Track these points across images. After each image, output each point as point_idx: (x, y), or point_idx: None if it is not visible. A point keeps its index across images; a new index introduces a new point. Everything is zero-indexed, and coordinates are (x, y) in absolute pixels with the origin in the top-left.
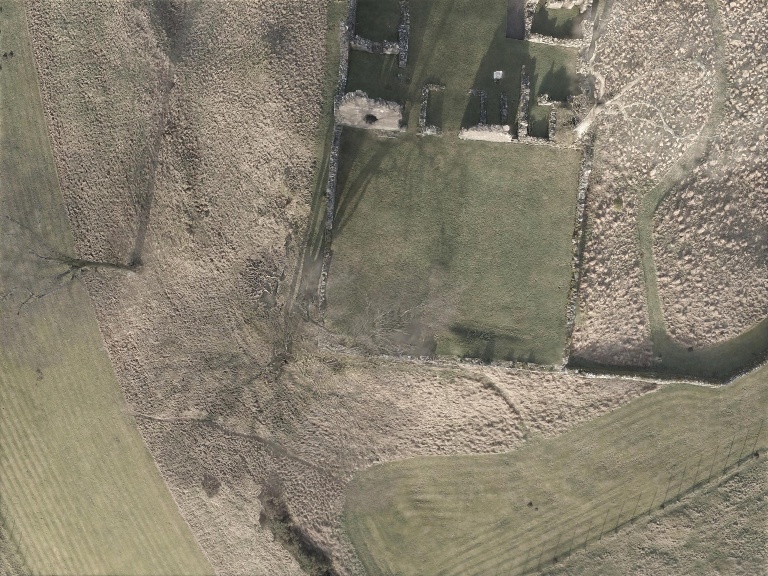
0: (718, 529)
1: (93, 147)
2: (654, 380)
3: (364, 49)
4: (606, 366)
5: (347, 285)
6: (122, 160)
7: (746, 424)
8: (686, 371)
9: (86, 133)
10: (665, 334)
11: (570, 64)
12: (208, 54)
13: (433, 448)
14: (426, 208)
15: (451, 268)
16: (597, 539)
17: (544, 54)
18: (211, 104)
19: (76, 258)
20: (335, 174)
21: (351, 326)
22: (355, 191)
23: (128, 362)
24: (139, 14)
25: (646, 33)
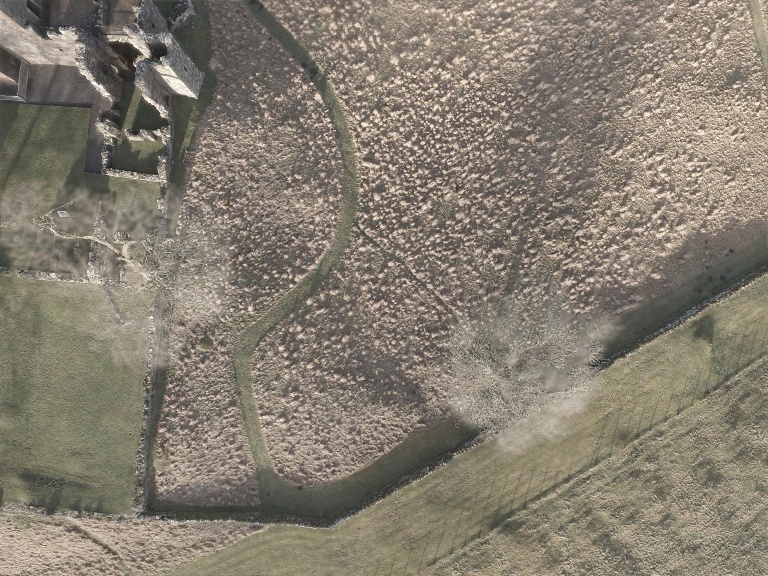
0: None
1: None
2: (250, 523)
3: None
4: (202, 508)
5: None
6: None
7: (362, 564)
8: (296, 510)
9: None
10: (273, 472)
11: (153, 199)
12: None
13: None
14: None
15: (23, 411)
16: None
17: (124, 188)
18: None
19: None
20: None
21: None
22: None
23: None
24: None
25: (251, 161)
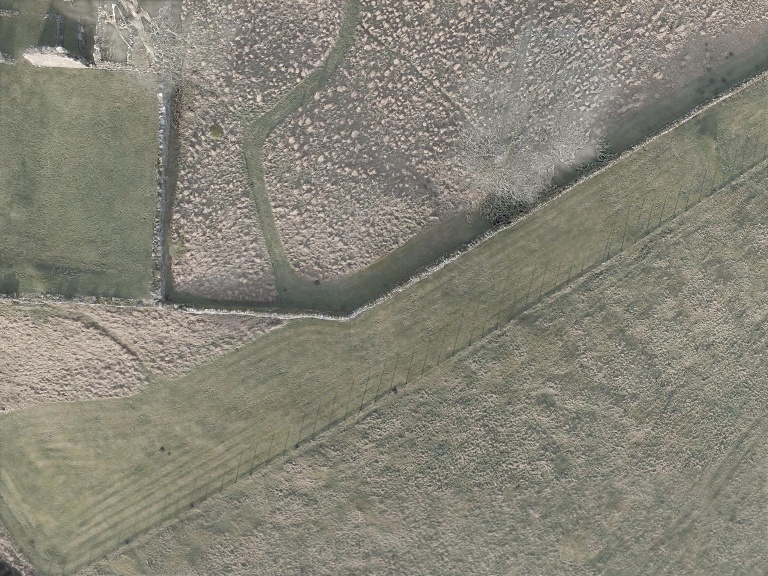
0: (358, 468)
1: None
2: (268, 314)
3: None
4: (219, 301)
5: None
6: None
7: (382, 358)
8: (313, 305)
9: None
10: (289, 267)
11: None
12: None
13: (53, 394)
14: (4, 140)
15: (35, 202)
16: (233, 482)
17: None
18: None
19: None
20: None
21: None
22: None
23: None
24: None
25: None
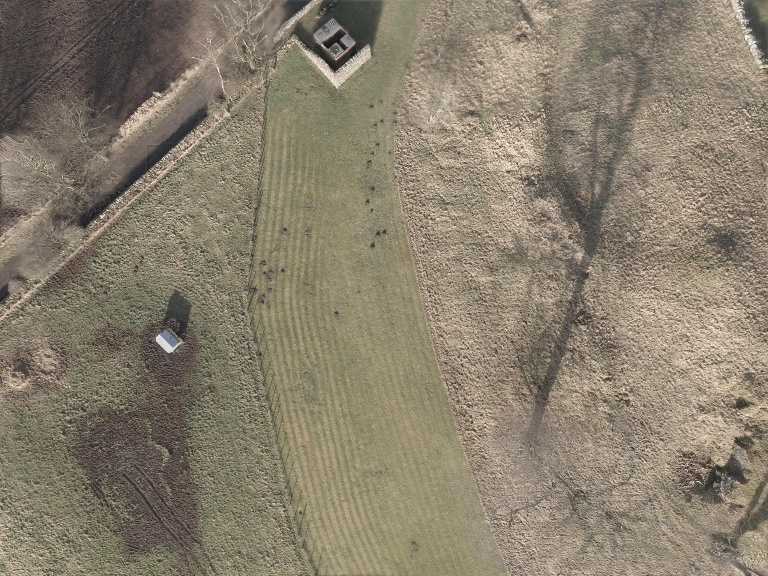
0: None
1: (478, 326)
2: None
3: None
4: None
5: None
6: (512, 340)
7: None
8: None
9: (469, 312)
10: None
11: None
12: (629, 248)
13: None
14: None
15: None
16: None
17: None
18: (638, 299)
19: (457, 433)
20: None
21: None
22: None
23: (512, 535)
24: (545, 204)
25: None
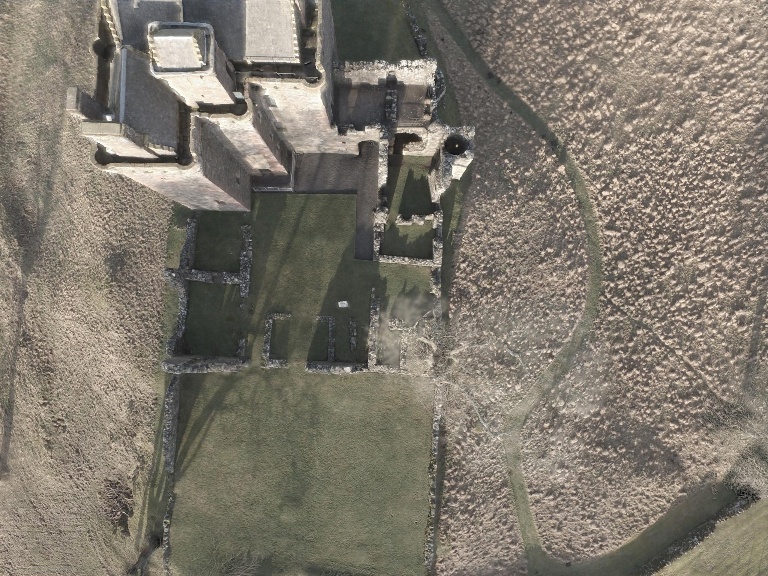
0: None
1: None
2: None
3: (203, 281)
4: None
5: (192, 529)
6: None
7: None
8: None
9: None
10: (541, 550)
11: (423, 283)
12: (59, 266)
13: None
14: (275, 442)
15: (303, 504)
16: None
17: (395, 274)
18: (62, 320)
19: None
20: (171, 421)
21: (197, 573)
22: (198, 430)
23: (2, 564)
24: None
25: (508, 238)
